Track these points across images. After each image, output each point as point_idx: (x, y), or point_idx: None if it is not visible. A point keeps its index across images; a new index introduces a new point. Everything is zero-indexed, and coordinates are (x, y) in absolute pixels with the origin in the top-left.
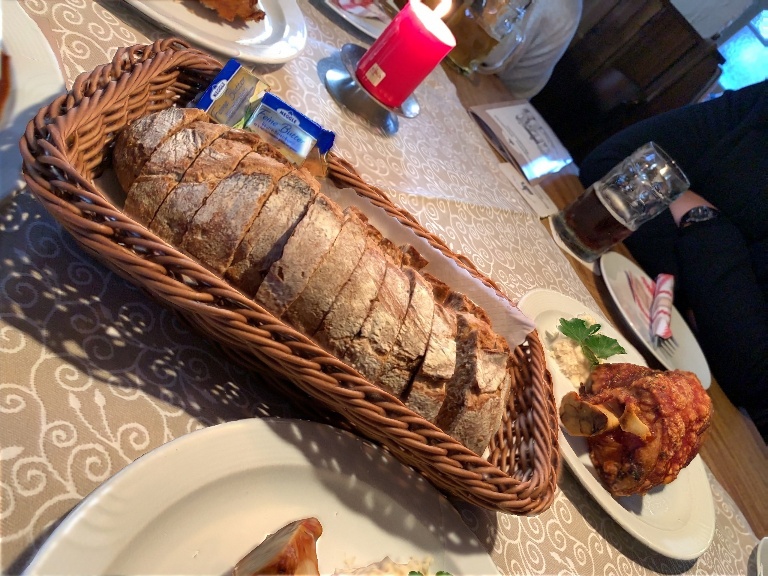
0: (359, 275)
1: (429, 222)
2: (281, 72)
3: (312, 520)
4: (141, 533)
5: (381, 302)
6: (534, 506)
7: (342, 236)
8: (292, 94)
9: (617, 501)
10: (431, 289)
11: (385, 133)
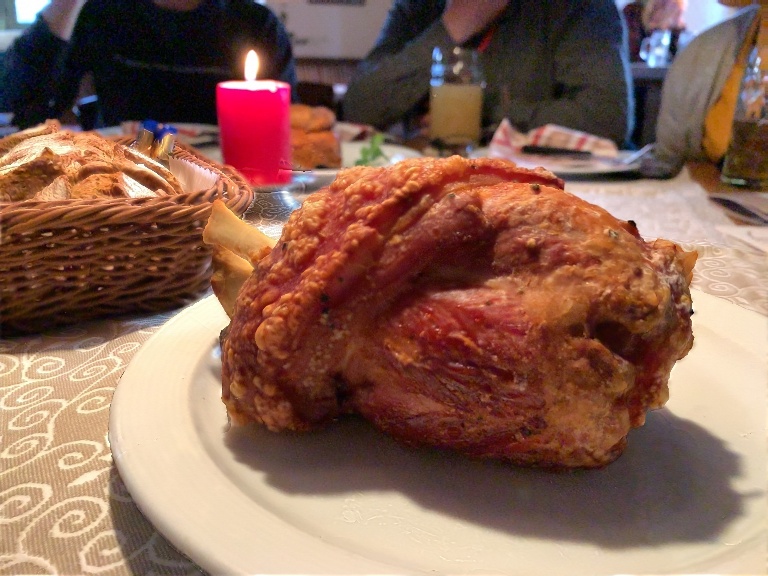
0: None
1: None
2: None
3: None
4: None
5: None
6: None
7: None
8: None
9: (243, 442)
10: (84, 151)
11: None
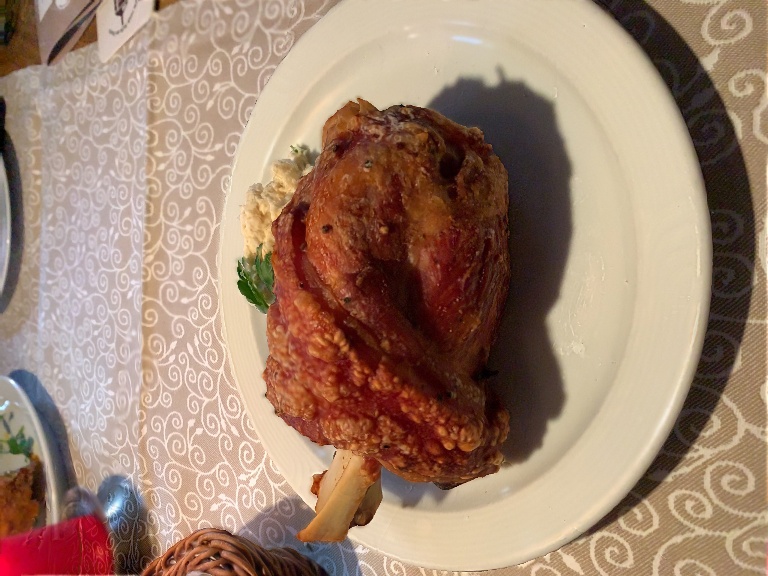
0: None
1: (168, 366)
2: (70, 443)
3: None
4: None
5: None
6: None
7: None
8: (83, 456)
9: (517, 448)
10: None
11: (97, 323)
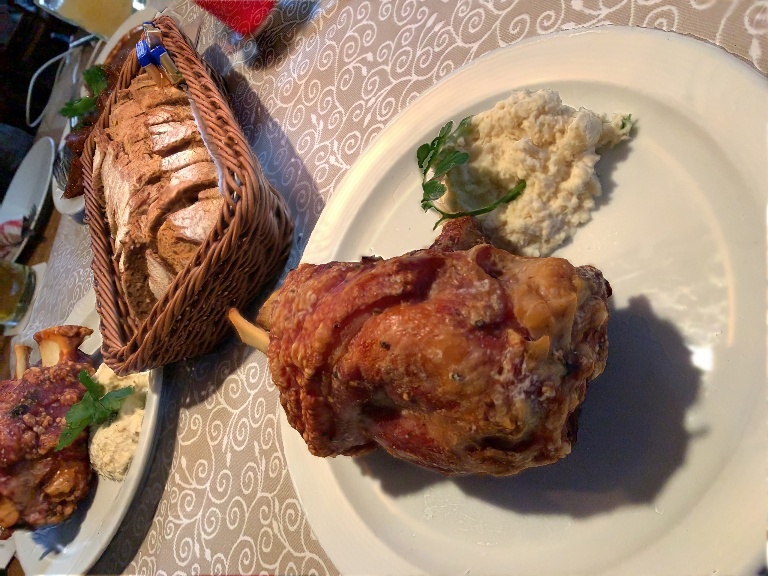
0: None
1: None
2: None
3: (62, 326)
4: (90, 314)
5: None
6: None
7: (105, 159)
8: None
9: None
10: (136, 182)
11: None
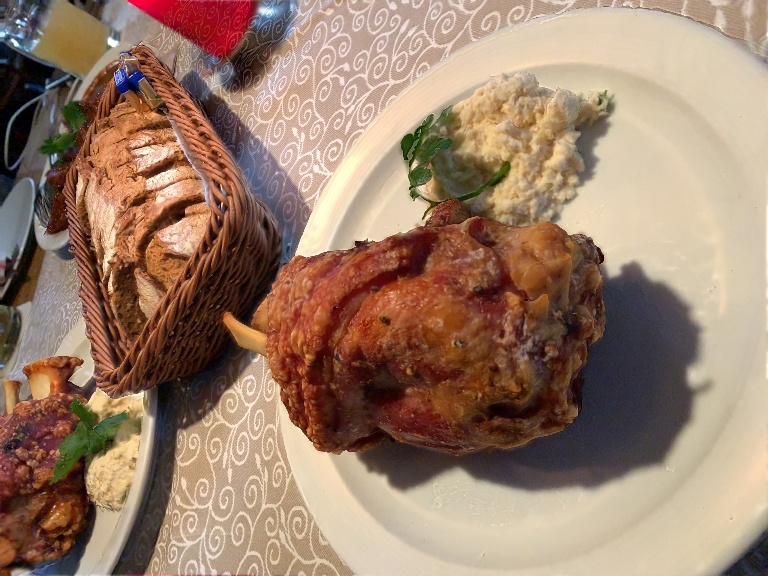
0: (89, 213)
1: (386, 5)
2: None
3: None
4: (79, 346)
5: (93, 229)
6: None
7: None
8: None
9: None
10: (121, 204)
11: None
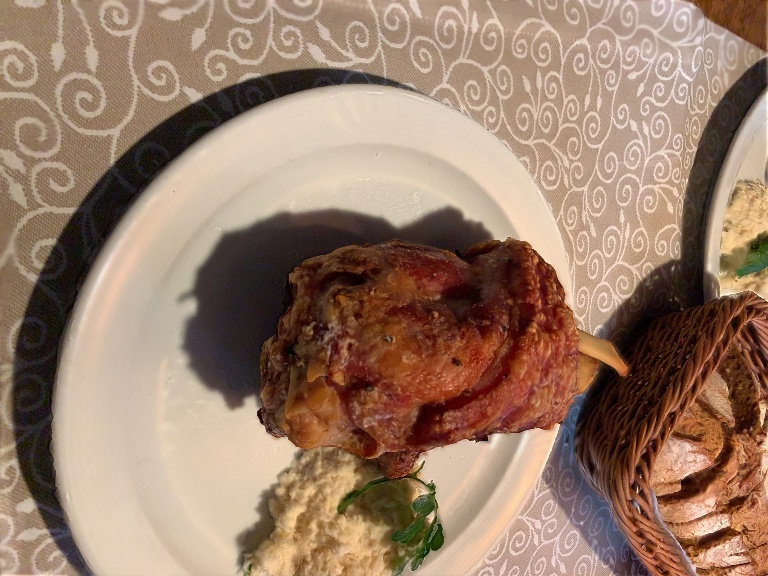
0: None
1: None
2: None
3: None
4: None
5: None
6: (761, 299)
7: None
8: None
9: None
10: None
11: None
